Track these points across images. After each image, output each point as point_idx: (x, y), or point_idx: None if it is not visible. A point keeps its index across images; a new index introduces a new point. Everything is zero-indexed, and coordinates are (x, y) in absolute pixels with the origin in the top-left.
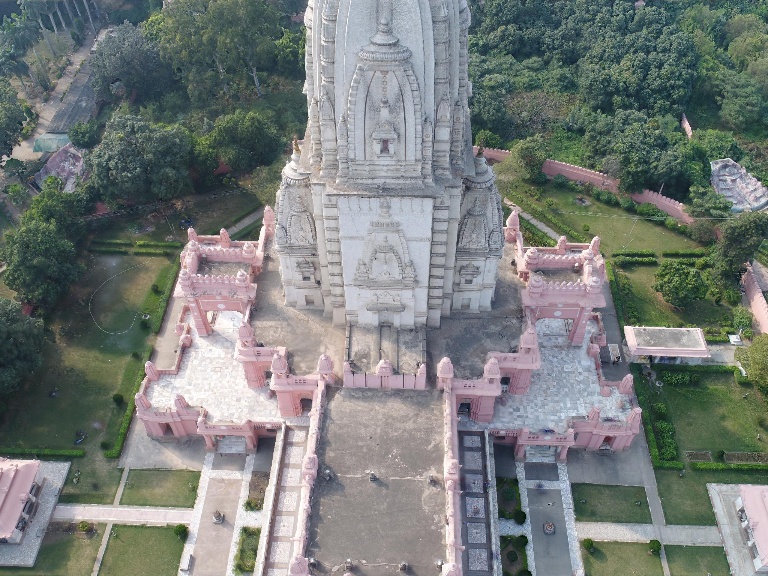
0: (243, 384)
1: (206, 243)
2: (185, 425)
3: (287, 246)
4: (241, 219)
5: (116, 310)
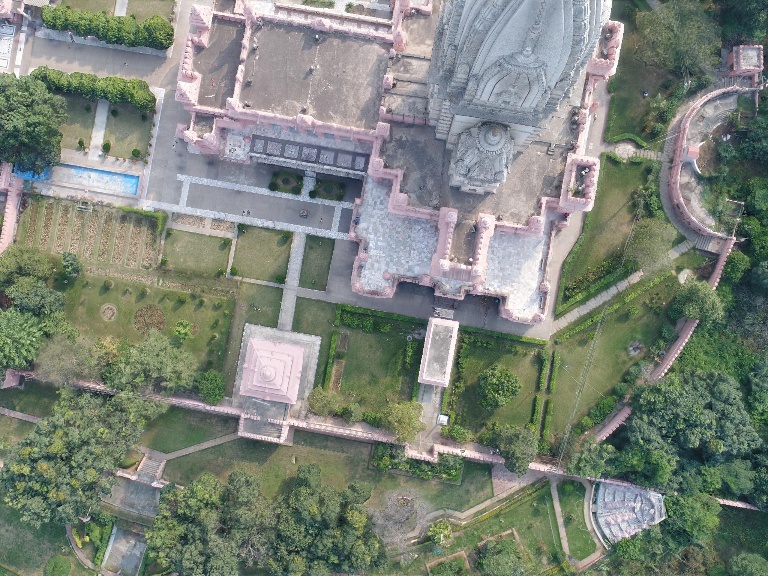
0: None
1: None
2: None
3: None
4: None
5: None
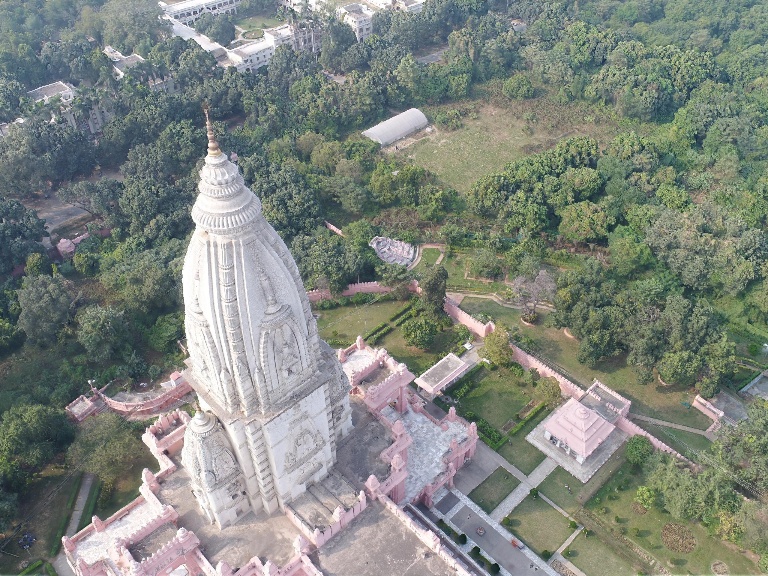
0: None
1: (82, 540)
2: None
3: (217, 483)
4: (75, 501)
5: None
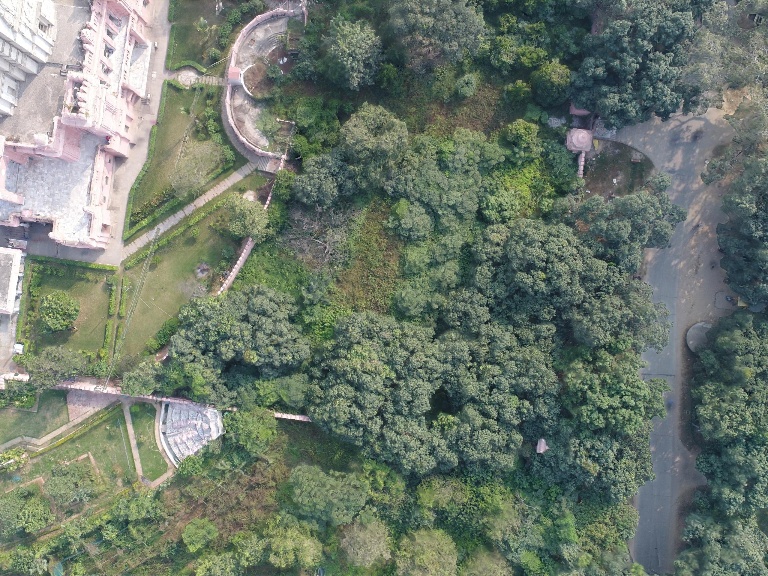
0: None
1: None
2: None
3: None
4: None
5: None
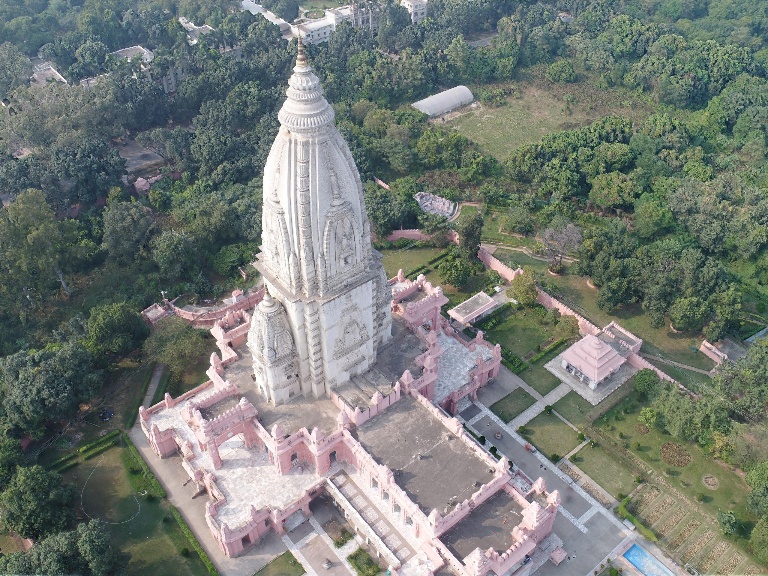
0: (277, 476)
1: (155, 412)
2: (258, 529)
3: (277, 360)
4: (147, 388)
5: (114, 504)
